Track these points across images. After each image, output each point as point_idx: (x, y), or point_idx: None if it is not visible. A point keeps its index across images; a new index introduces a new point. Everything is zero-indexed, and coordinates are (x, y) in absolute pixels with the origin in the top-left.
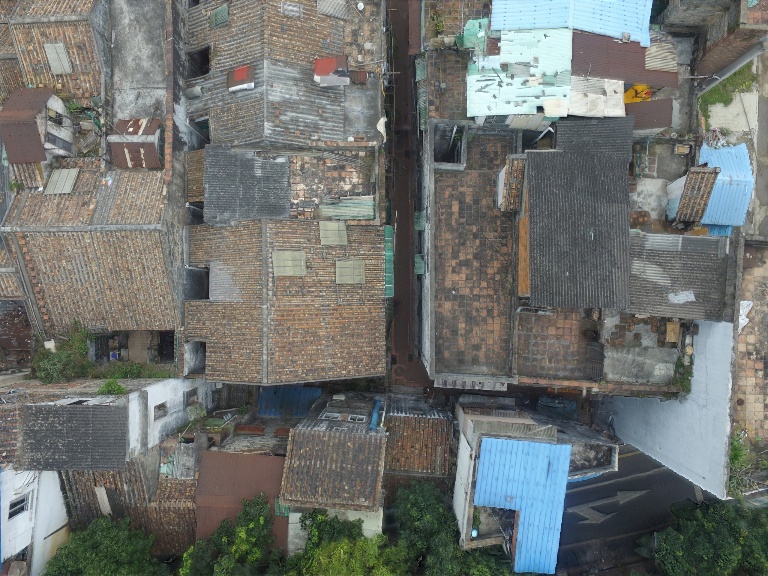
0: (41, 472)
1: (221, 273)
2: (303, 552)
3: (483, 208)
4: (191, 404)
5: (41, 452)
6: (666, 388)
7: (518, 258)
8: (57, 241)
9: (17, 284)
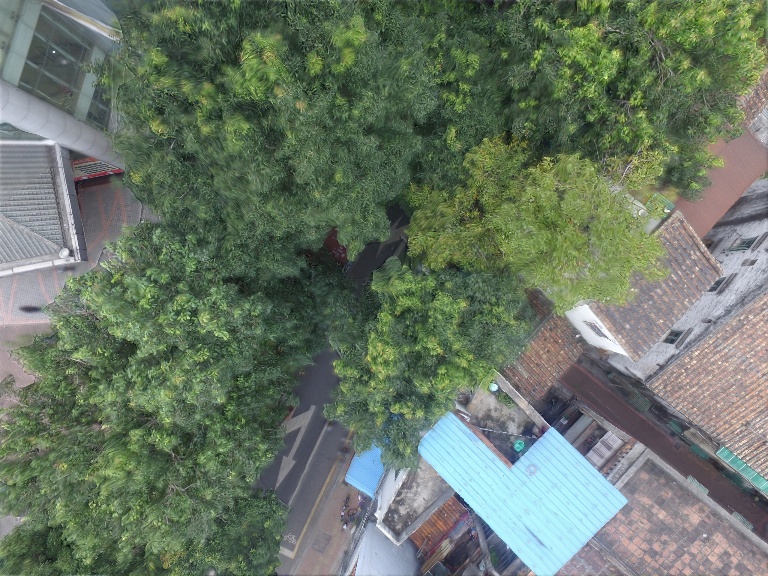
0: None
1: None
2: None
3: None
4: None
5: None
6: None
7: None
8: None
9: None
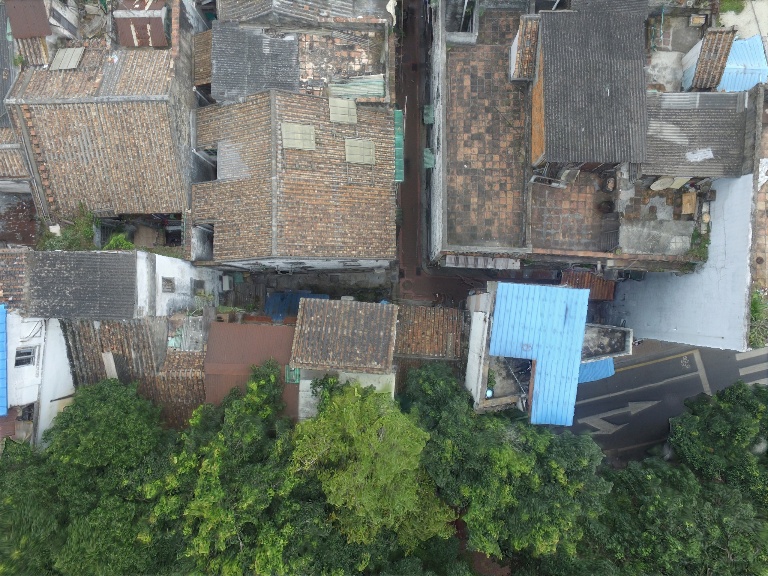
0: (48, 330)
1: (229, 151)
2: (314, 419)
3: (495, 82)
4: (198, 295)
5: (48, 299)
6: (683, 257)
7: (531, 128)
8: (63, 115)
9: (22, 162)
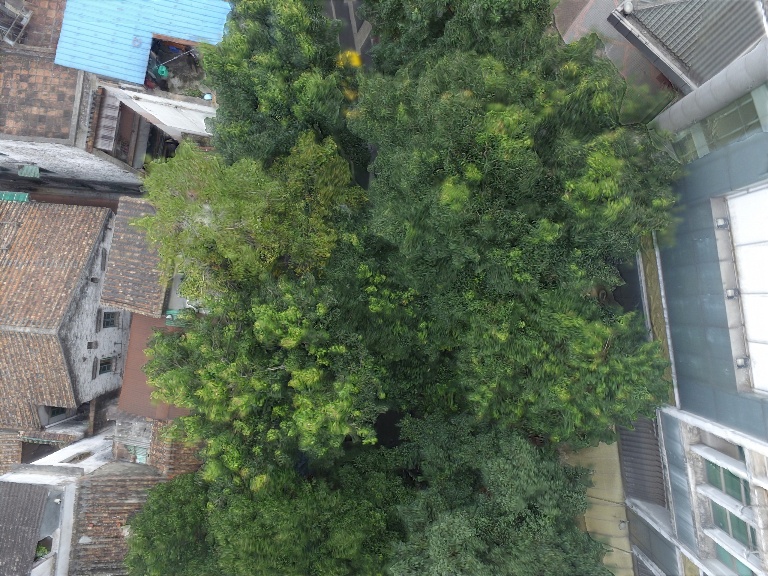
0: None
1: None
2: None
3: None
4: None
5: None
6: None
7: None
8: None
9: None
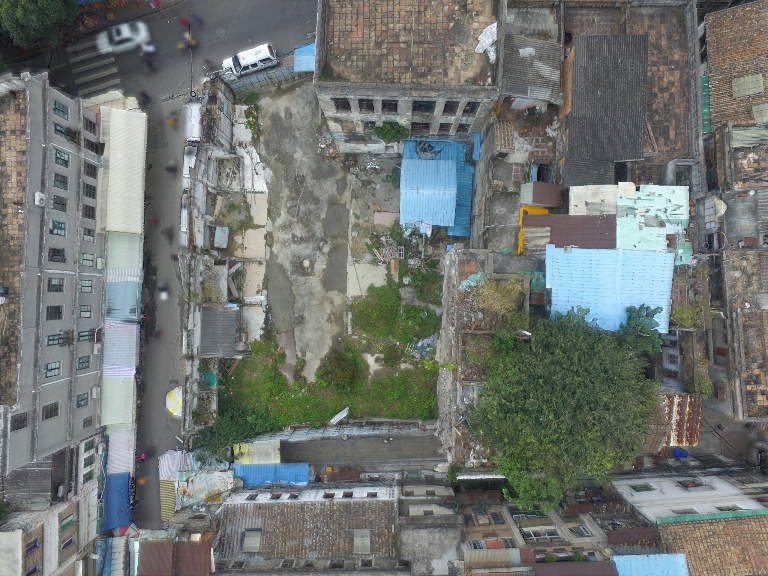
0: None
1: None
2: None
3: None
4: None
5: None
6: None
7: None
8: None
9: None
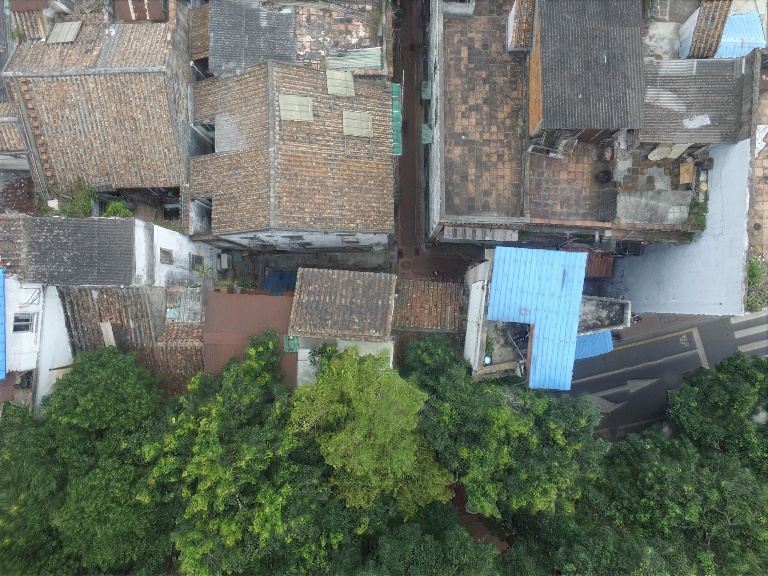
0: (46, 298)
1: (227, 124)
2: None
3: (492, 53)
4: (197, 271)
5: (46, 265)
6: (680, 226)
7: (529, 98)
8: (60, 87)
9: (20, 136)
